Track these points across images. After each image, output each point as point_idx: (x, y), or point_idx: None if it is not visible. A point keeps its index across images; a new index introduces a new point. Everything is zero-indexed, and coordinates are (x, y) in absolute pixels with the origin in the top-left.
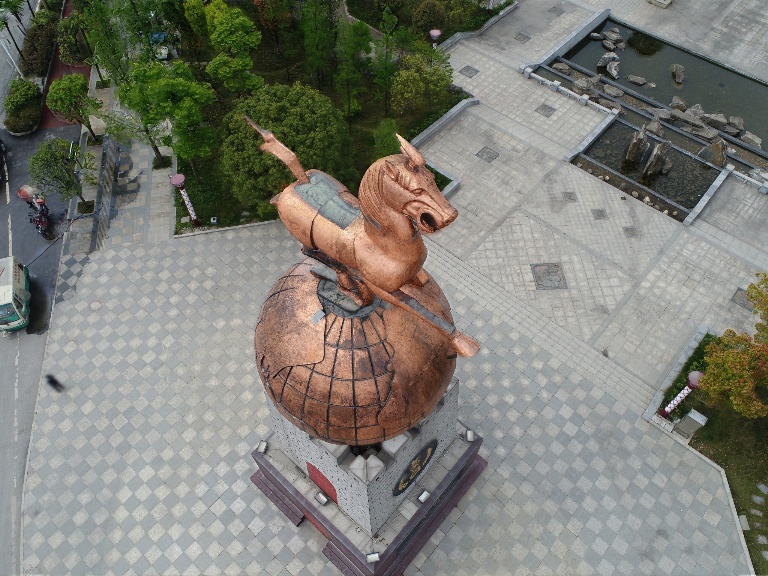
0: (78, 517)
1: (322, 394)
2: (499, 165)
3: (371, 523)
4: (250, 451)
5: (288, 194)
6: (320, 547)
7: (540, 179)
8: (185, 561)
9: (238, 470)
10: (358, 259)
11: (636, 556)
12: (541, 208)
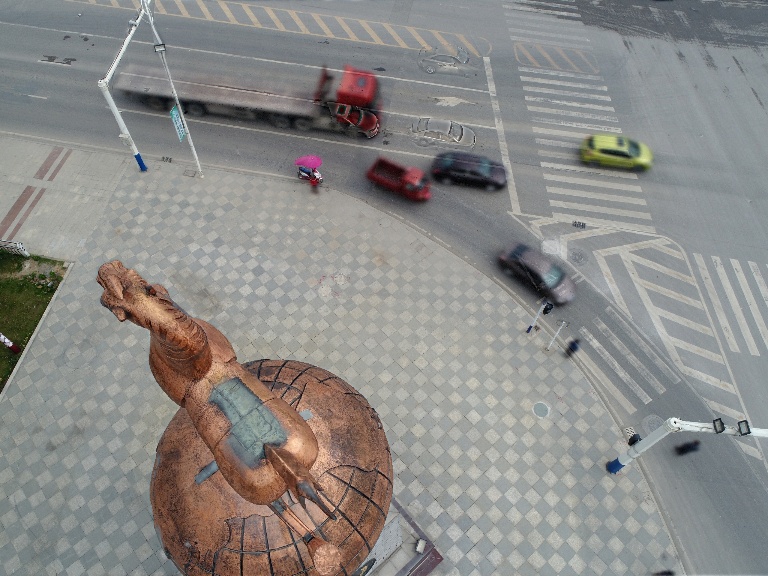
0: (619, 546)
1: (317, 370)
2: None
3: None
4: None
5: (297, 434)
6: None
7: None
8: (501, 486)
9: (458, 574)
10: (232, 352)
11: (88, 432)
12: None
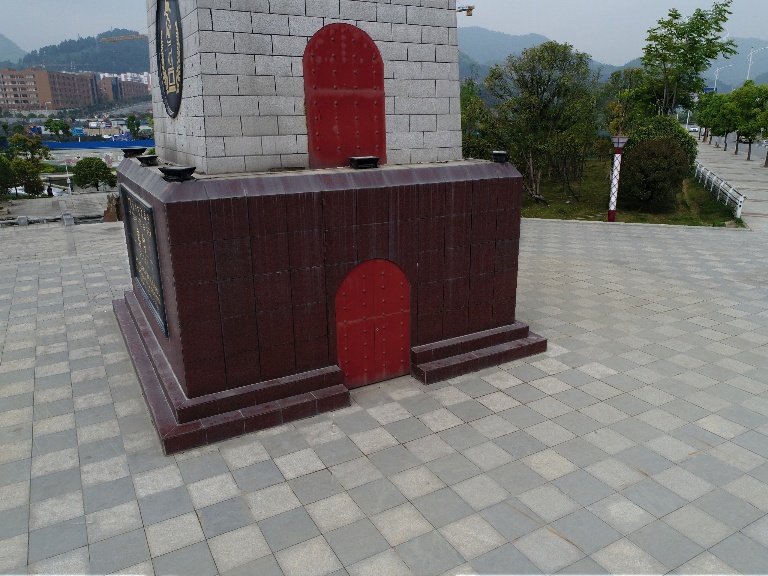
0: None
1: None
2: (0, 241)
3: (457, 70)
4: (82, 449)
5: None
6: (412, 386)
7: (64, 233)
8: None
9: (106, 476)
10: None
11: None
12: (98, 237)
